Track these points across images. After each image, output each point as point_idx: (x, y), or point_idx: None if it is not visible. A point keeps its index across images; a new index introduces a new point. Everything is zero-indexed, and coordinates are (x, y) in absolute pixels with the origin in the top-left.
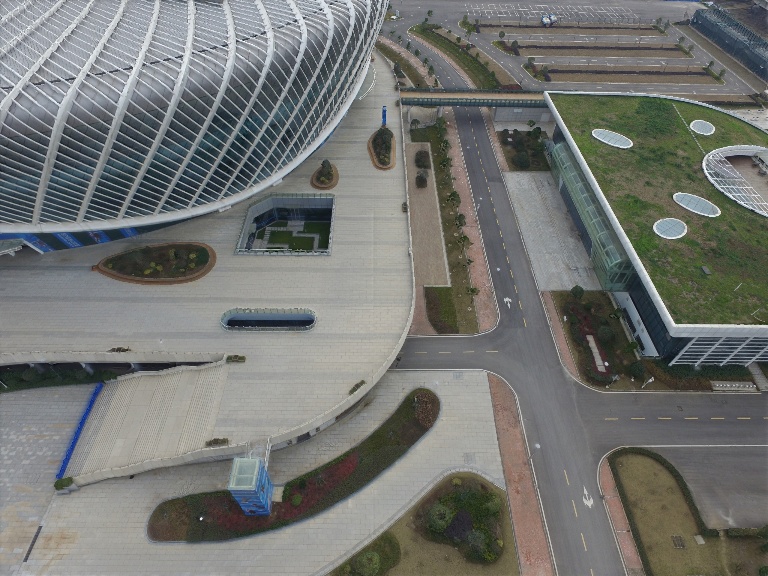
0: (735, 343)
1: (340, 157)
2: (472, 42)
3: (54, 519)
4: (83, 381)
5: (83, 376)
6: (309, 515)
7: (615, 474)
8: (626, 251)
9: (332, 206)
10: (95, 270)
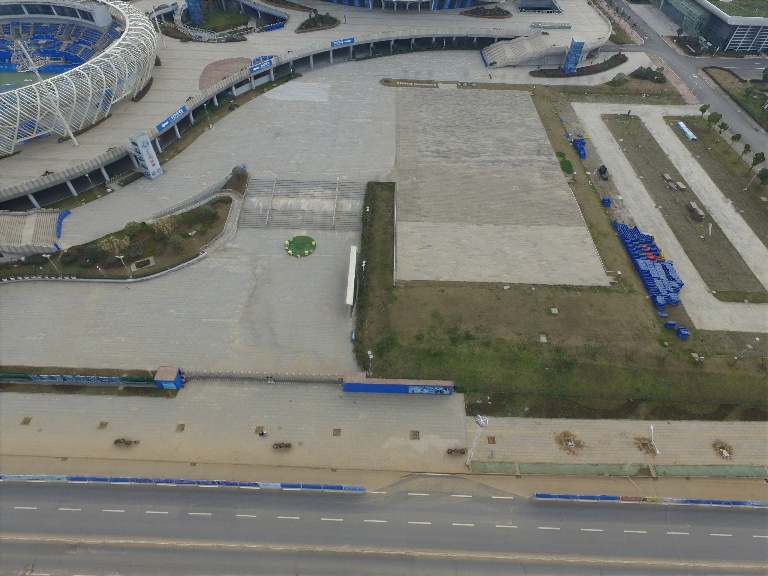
0: (754, 32)
1: None
2: None
3: (493, 73)
4: (475, 47)
5: (477, 43)
6: (590, 73)
7: (705, 71)
8: (705, 5)
9: (553, 2)
10: (461, 14)
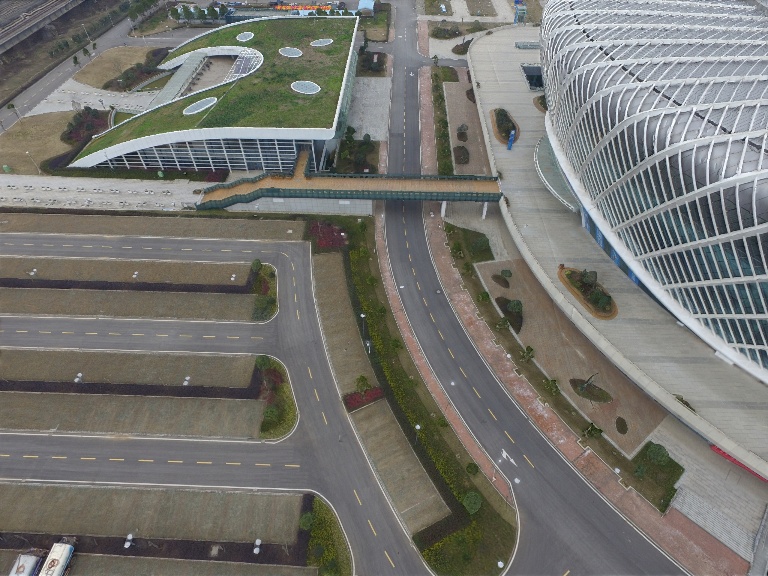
0: None
1: (540, 118)
2: (345, 427)
3: None
4: None
5: None
6: None
7: None
8: None
9: None
10: None
